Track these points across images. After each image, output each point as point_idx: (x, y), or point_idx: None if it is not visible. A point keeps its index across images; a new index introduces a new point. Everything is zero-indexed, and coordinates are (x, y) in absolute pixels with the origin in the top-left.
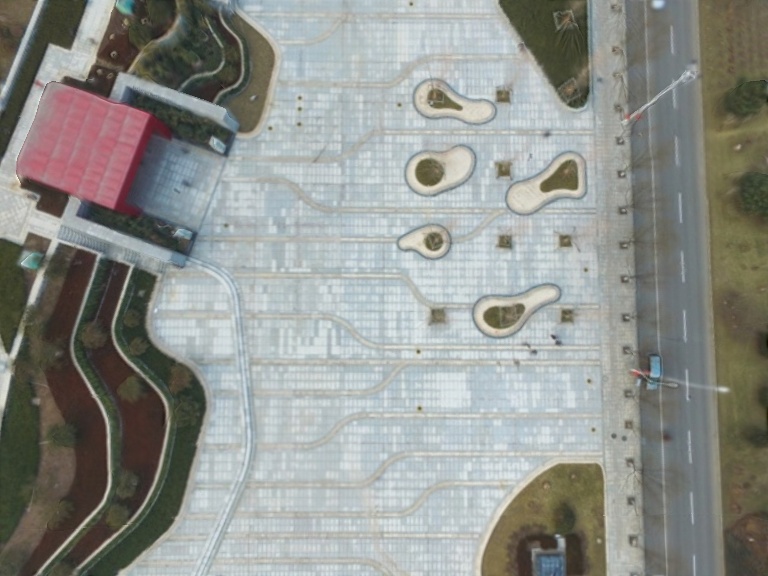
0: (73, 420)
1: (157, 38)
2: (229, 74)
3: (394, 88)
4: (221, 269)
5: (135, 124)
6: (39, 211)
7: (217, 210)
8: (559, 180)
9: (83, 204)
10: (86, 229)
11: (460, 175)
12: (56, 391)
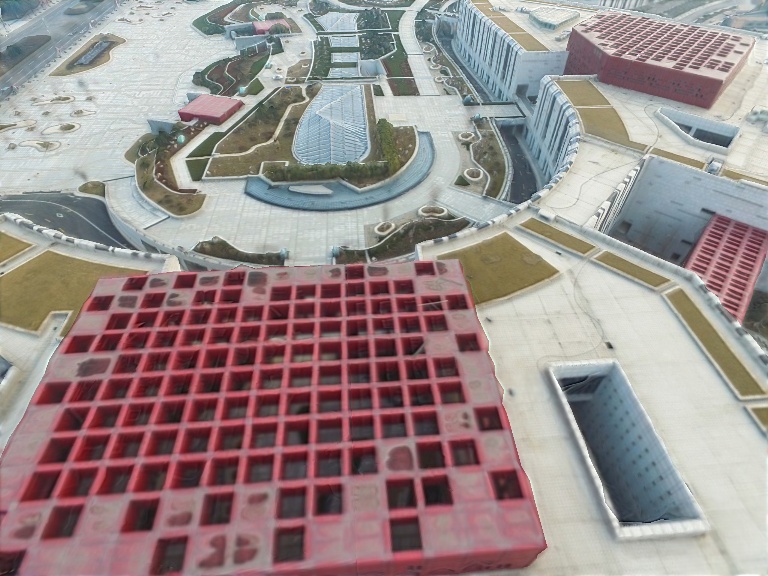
0: (236, 70)
1: None
2: None
3: None
4: None
5: None
6: None
7: None
8: (5, 126)
9: None
10: None
11: (53, 127)
12: None
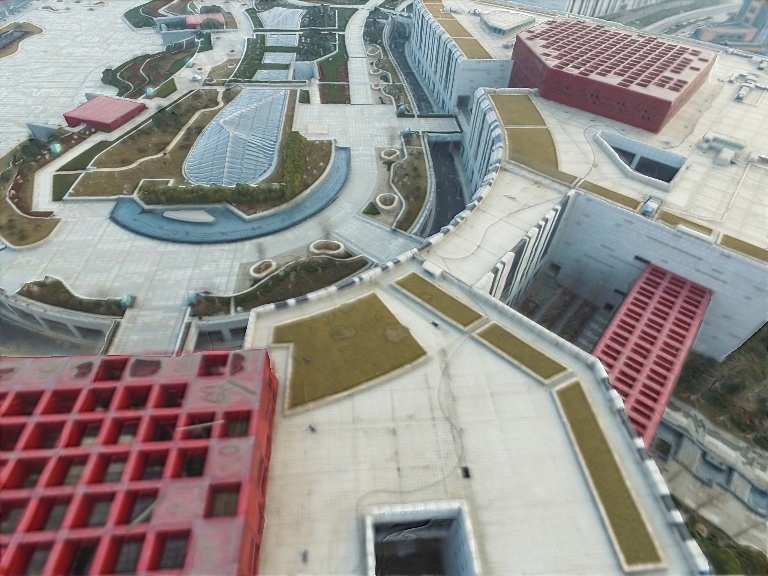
0: (152, 68)
1: None
2: None
3: None
4: None
5: (73, 112)
6: None
7: None
8: None
9: None
10: None
11: None
12: None
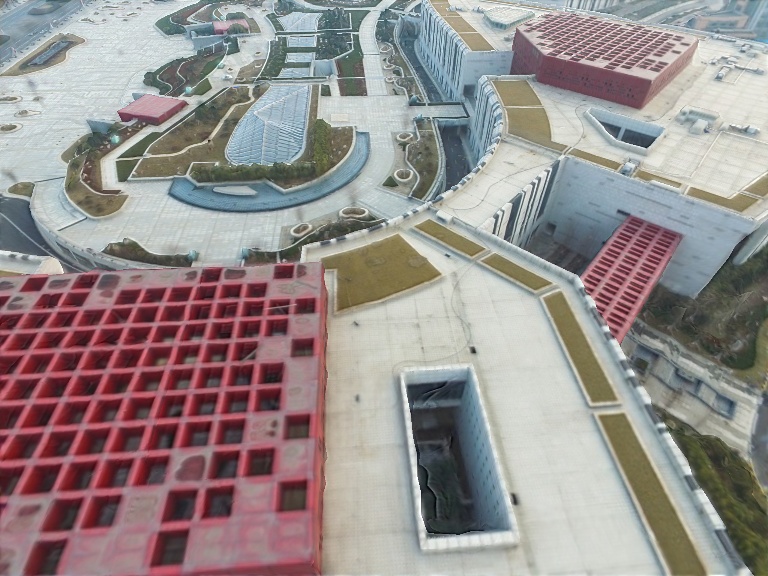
0: (187, 70)
1: None
2: None
3: (5, 149)
4: None
5: (125, 109)
6: None
7: None
8: None
9: None
10: None
11: None
12: None
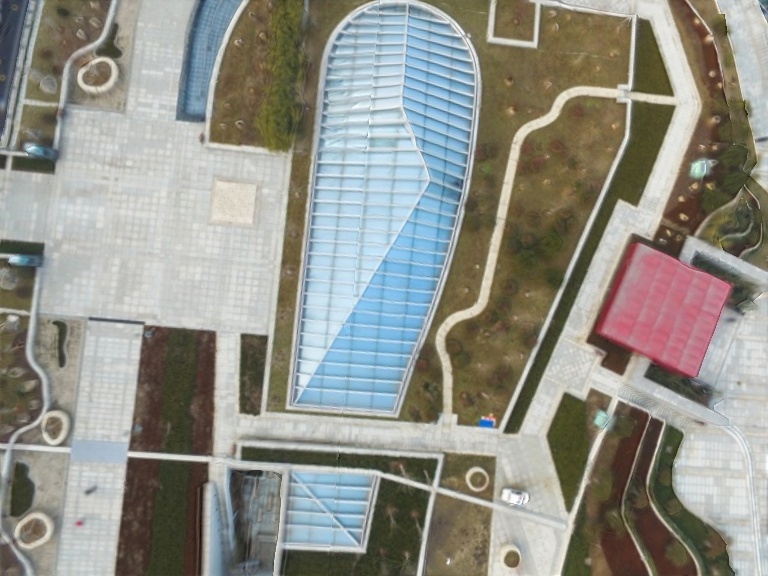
0: None
1: (723, 205)
2: (756, 236)
3: None
4: (733, 427)
5: (718, 294)
6: (603, 367)
7: (731, 367)
8: None
9: (658, 367)
10: (653, 391)
11: None
12: (609, 552)
